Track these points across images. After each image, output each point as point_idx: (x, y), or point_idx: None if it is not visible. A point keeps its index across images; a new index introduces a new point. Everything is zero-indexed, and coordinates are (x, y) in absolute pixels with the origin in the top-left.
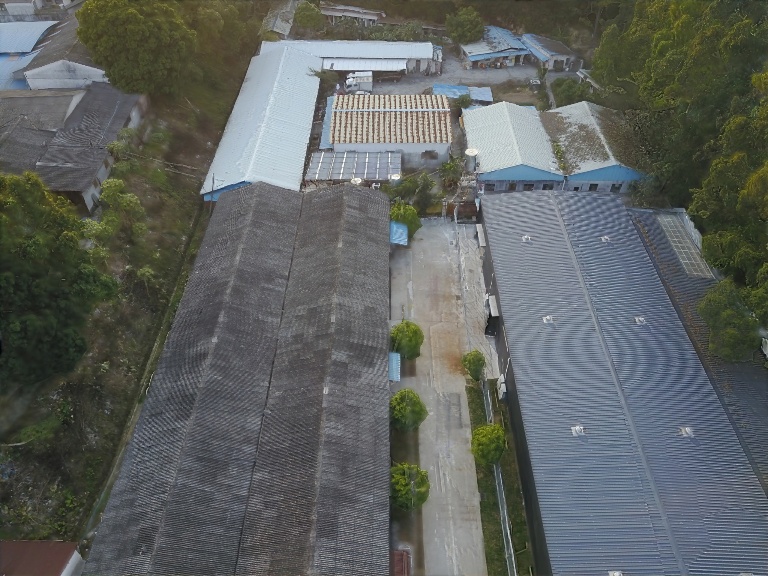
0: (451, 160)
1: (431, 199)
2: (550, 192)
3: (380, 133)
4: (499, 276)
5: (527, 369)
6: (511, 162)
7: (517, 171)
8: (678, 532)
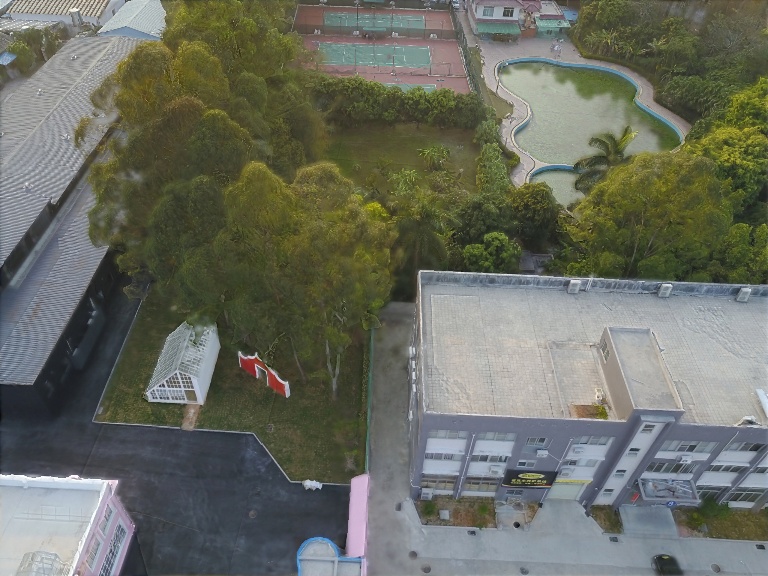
0: (94, 28)
1: (54, 46)
2: (117, 36)
3: (48, 8)
4: (36, 74)
5: (2, 112)
6: (121, 25)
7: (125, 32)
8: (7, 168)
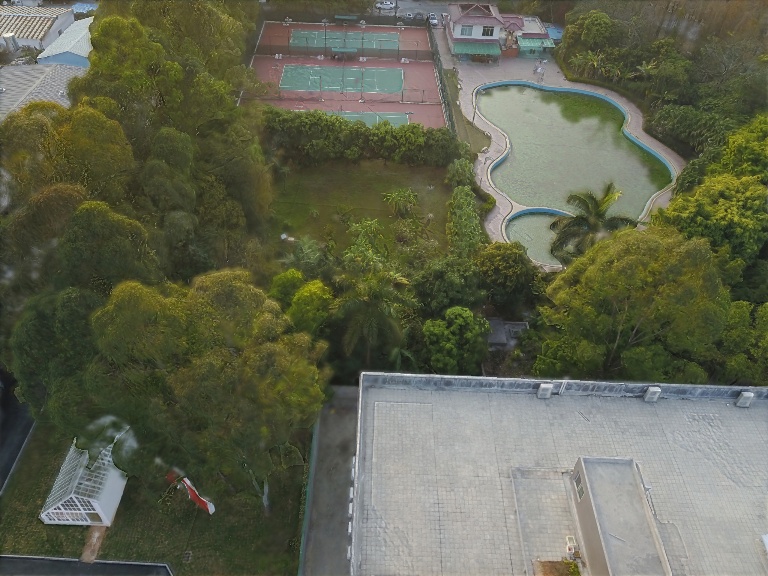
0: None
1: None
2: (54, 65)
3: None
4: None
5: None
6: (62, 50)
7: (67, 58)
8: None
